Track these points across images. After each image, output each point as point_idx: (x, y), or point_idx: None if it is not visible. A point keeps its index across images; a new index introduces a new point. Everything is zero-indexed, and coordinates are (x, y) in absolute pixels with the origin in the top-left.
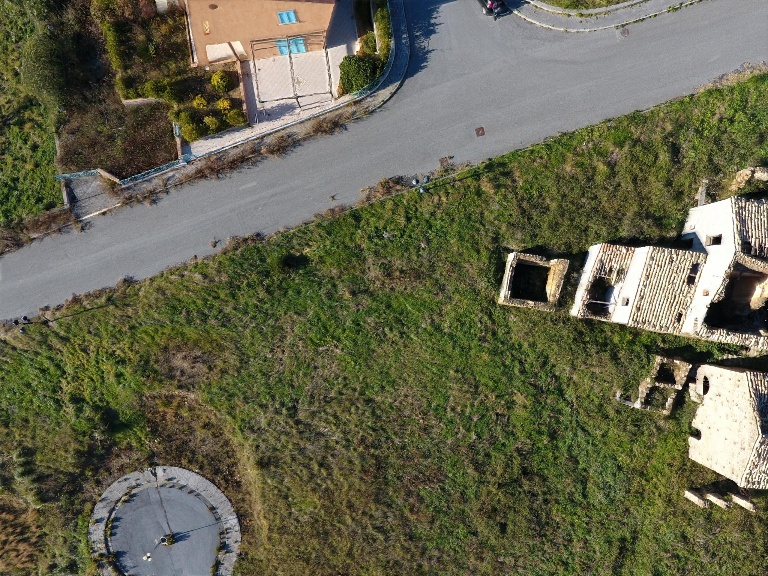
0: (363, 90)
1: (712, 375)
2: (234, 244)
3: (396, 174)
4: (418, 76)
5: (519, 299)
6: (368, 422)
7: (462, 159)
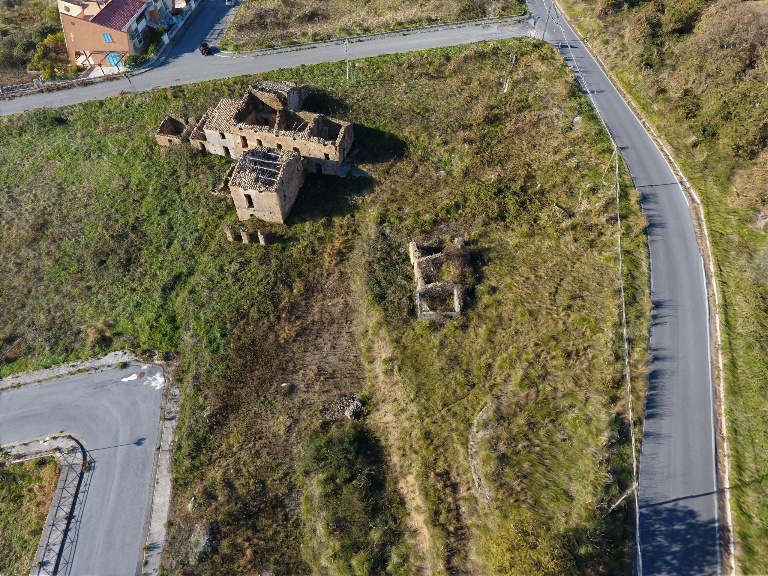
0: (132, 67)
1: None
2: (34, 109)
3: (130, 91)
4: (162, 67)
5: None
6: (53, 199)
7: (164, 87)
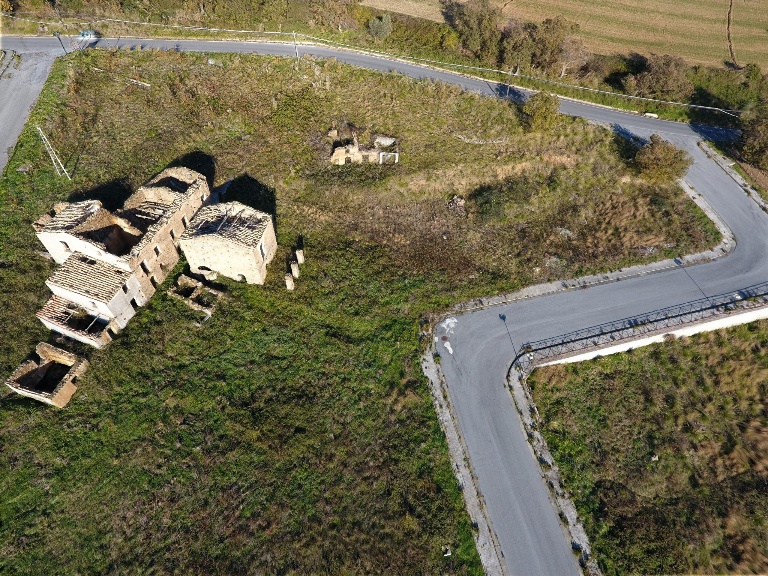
0: None
1: (194, 264)
2: None
3: None
4: None
5: (57, 386)
6: (137, 572)
7: None
